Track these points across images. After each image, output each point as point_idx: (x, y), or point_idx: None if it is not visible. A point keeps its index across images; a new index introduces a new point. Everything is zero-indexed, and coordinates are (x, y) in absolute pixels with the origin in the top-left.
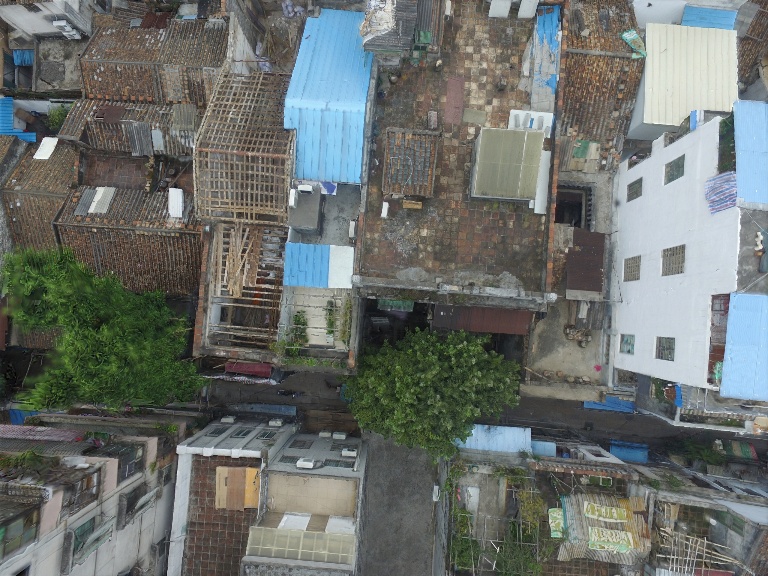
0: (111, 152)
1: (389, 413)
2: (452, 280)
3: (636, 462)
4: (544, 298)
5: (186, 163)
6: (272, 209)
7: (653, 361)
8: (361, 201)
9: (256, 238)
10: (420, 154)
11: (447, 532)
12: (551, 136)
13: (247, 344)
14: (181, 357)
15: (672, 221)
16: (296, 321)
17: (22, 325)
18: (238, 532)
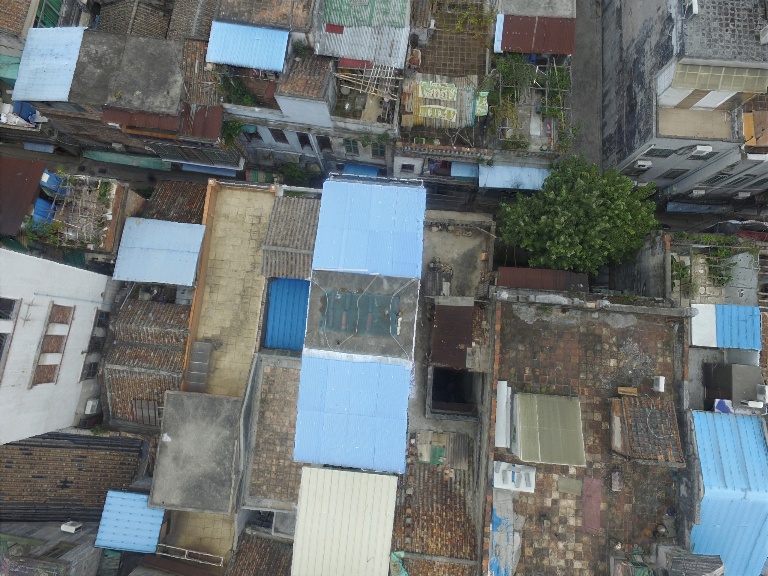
0: None
1: None
2: (582, 316)
3: (362, 164)
4: (508, 295)
5: None
6: None
7: None
8: None
9: (767, 361)
10: (644, 439)
11: None
12: None
13: (759, 258)
14: None
15: None
16: None
17: None
18: None
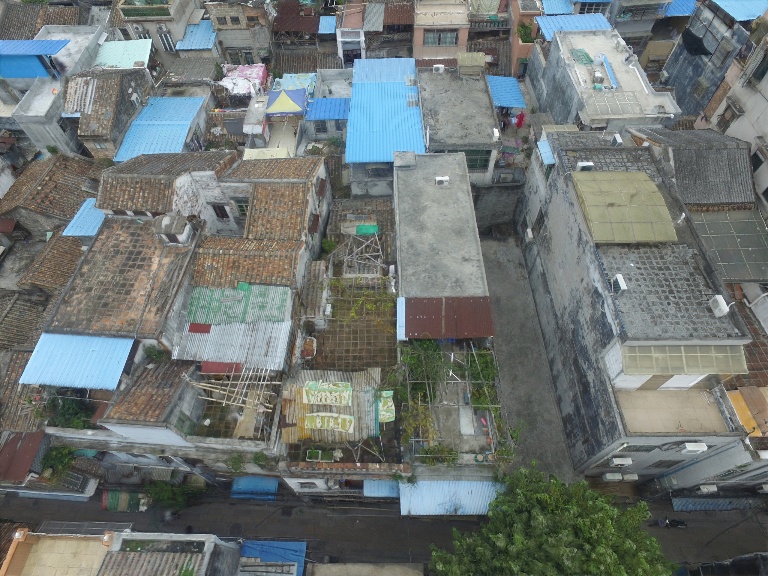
0: None
1: None
2: None
3: None
4: None
5: None
6: None
7: None
8: None
9: None
10: None
11: None
12: None
13: None
14: None
15: None
16: None
17: None
18: None
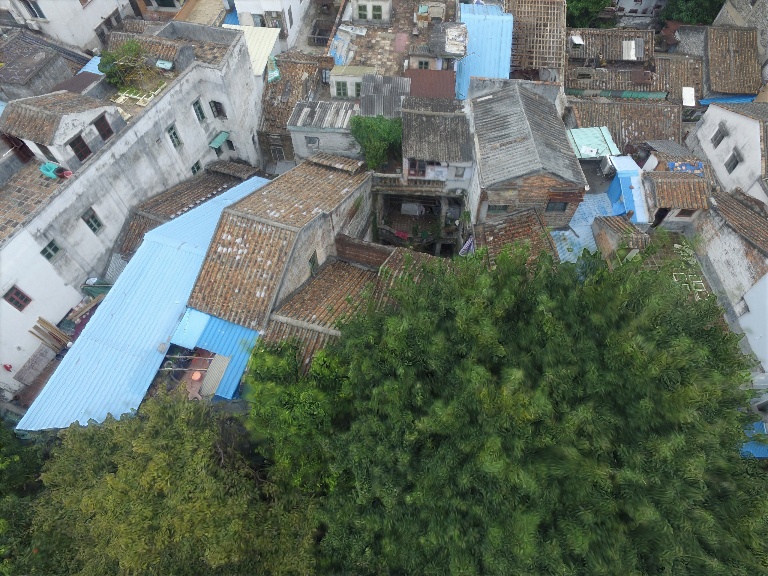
0: None
1: None
2: None
3: None
4: None
5: None
6: None
7: None
8: None
9: None
10: None
11: None
12: None
13: None
14: None
15: None
16: None
17: None
18: None
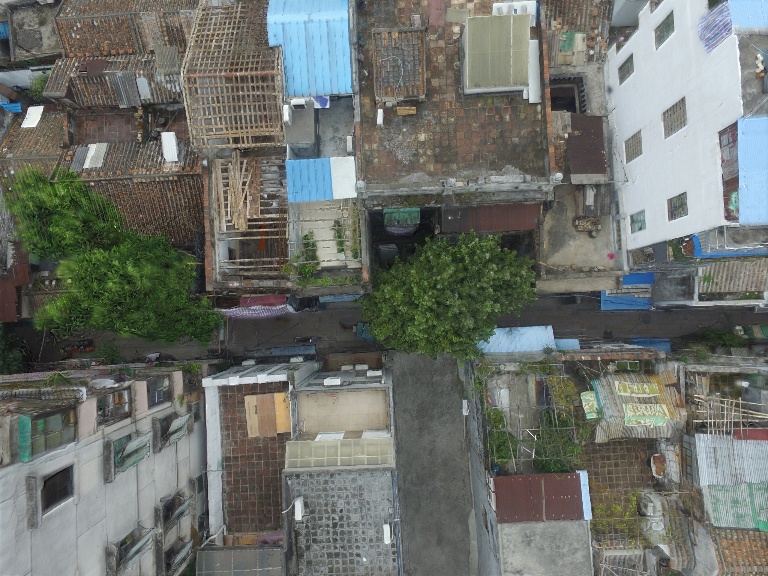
0: (98, 110)
1: (409, 322)
2: None
3: None
4: (550, 181)
5: (175, 112)
6: (267, 129)
7: (667, 225)
8: (355, 111)
9: (255, 169)
10: (408, 53)
11: (482, 433)
12: (536, 25)
13: (259, 276)
14: (195, 290)
15: (668, 81)
16: (305, 244)
17: (31, 296)
18: (274, 461)
